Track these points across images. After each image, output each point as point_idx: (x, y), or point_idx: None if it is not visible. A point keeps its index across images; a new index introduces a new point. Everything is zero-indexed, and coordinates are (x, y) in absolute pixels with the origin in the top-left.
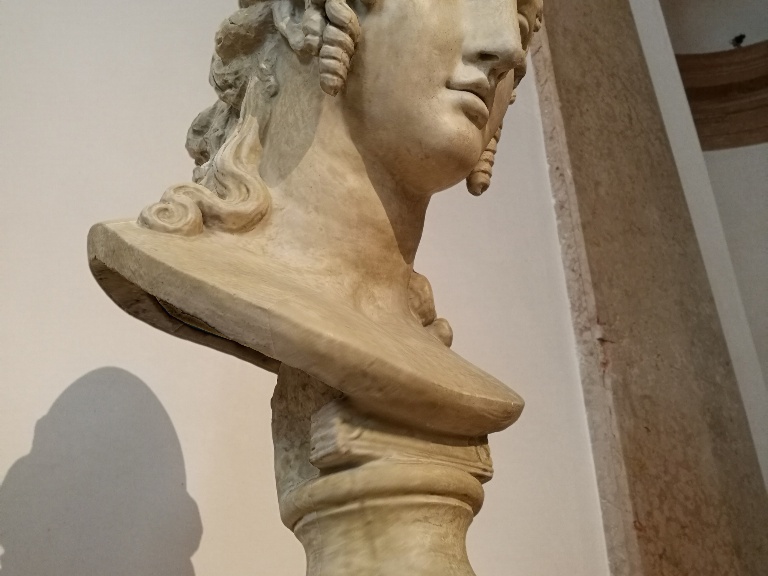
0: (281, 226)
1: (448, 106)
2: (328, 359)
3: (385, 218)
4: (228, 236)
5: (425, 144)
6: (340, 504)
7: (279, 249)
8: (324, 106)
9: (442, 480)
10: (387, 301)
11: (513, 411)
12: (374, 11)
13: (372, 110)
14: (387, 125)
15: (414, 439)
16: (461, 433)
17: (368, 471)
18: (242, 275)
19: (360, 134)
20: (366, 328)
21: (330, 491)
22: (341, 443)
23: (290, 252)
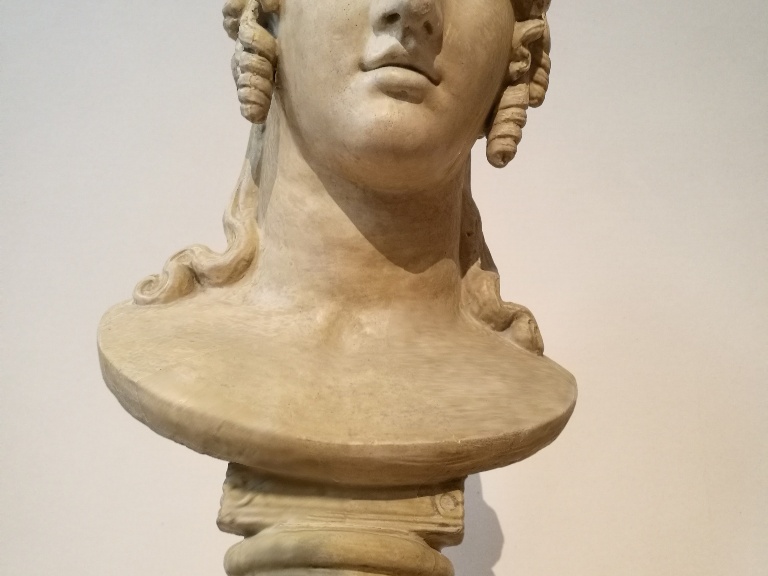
0: (263, 268)
1: (363, 93)
2: (183, 427)
3: (356, 234)
4: (217, 291)
5: (348, 145)
6: (240, 575)
7: (259, 294)
8: (280, 131)
9: (320, 551)
10: (381, 324)
11: (467, 449)
12: (281, 16)
13: (302, 124)
14: (316, 135)
15: (324, 498)
16: (397, 484)
17: (251, 542)
18: (173, 339)
19: (307, 151)
20: (263, 379)
21: (228, 562)
22: (226, 512)
23: (267, 295)
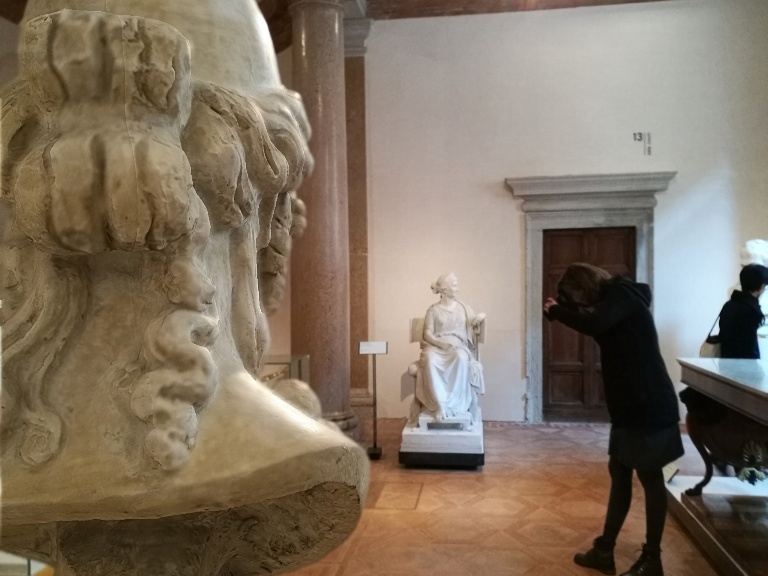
0: None
1: None
2: None
3: None
4: None
5: None
6: None
7: None
8: None
9: None
10: None
11: None
12: None
13: None
14: None
15: None
16: None
17: None
18: None
19: None
20: None
21: None
22: None
23: None
